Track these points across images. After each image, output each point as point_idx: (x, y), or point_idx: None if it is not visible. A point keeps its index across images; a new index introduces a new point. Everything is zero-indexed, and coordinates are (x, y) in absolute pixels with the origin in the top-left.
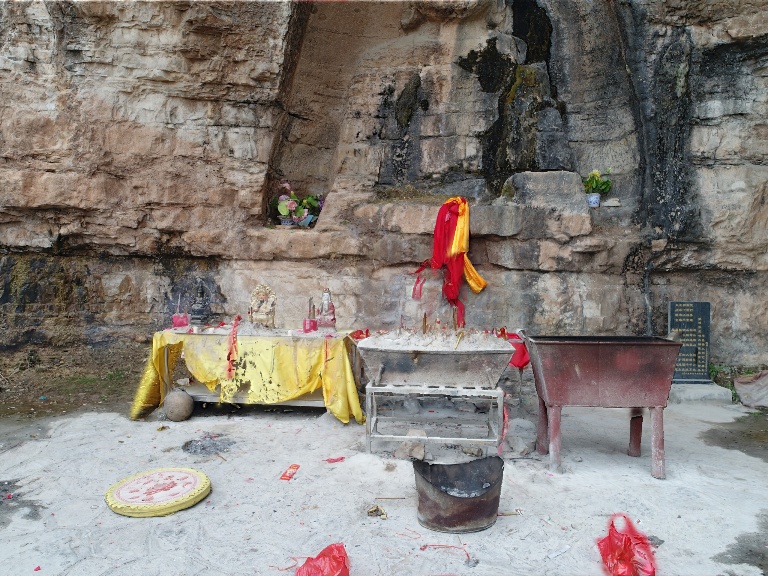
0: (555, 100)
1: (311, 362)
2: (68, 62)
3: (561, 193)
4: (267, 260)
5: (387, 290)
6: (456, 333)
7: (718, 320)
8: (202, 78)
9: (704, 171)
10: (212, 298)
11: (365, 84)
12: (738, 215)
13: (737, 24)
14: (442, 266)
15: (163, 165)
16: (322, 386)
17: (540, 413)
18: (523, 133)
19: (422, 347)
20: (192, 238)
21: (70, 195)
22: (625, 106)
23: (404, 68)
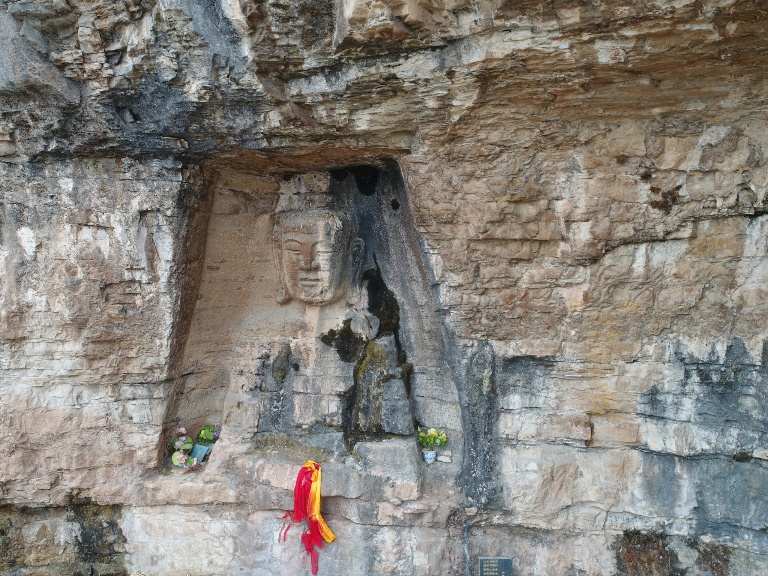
0: (403, 365)
1: None
2: None
3: (395, 464)
4: (162, 505)
5: (259, 533)
6: None
7: (524, 566)
8: (101, 372)
9: (508, 450)
10: (115, 539)
11: (246, 350)
12: (530, 494)
13: (526, 345)
14: (299, 522)
15: (71, 438)
16: None
17: None
18: (372, 401)
19: None
20: (97, 493)
21: None
22: None
23: (277, 339)
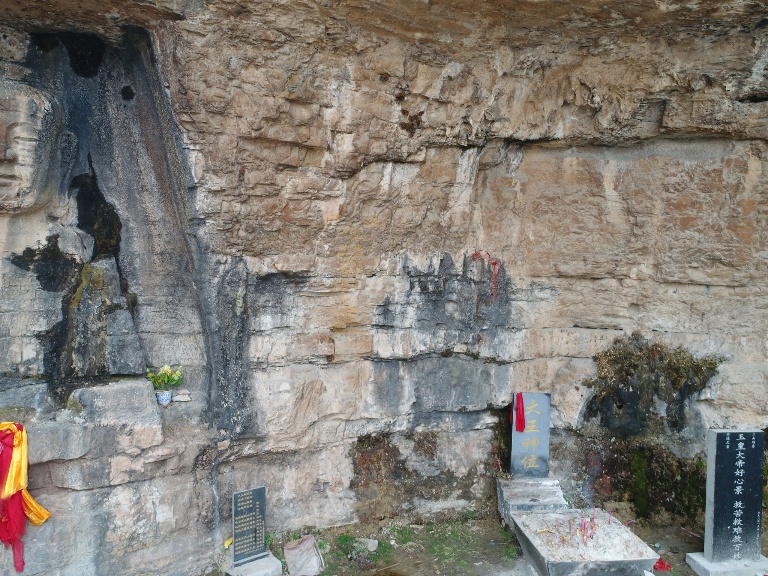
0: (126, 295)
1: None
2: None
3: (132, 407)
4: None
5: None
6: None
7: (272, 494)
8: None
9: (259, 374)
10: None
11: None
12: (285, 414)
13: (282, 260)
14: None
15: None
16: None
17: None
18: (91, 337)
19: None
20: None
21: None
22: (193, 308)
23: None
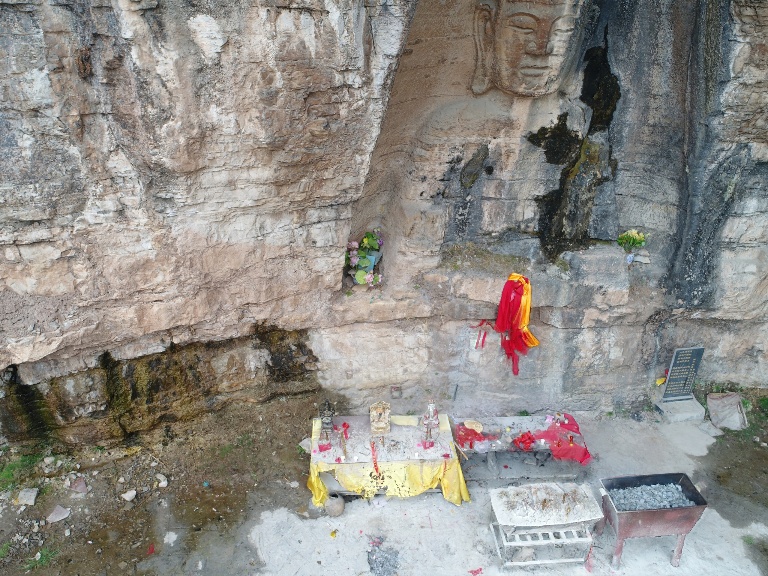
0: (610, 163)
1: (434, 474)
2: (159, 206)
3: (609, 273)
4: (350, 324)
5: (454, 341)
6: (565, 509)
7: (705, 350)
8: (291, 199)
9: (727, 253)
10: (306, 360)
11: (433, 153)
12: (744, 295)
13: None
14: None
15: (257, 272)
16: (441, 486)
17: (603, 519)
18: (580, 206)
19: (544, 522)
20: (286, 321)
21: (180, 317)
22: (673, 181)
23: (474, 140)
